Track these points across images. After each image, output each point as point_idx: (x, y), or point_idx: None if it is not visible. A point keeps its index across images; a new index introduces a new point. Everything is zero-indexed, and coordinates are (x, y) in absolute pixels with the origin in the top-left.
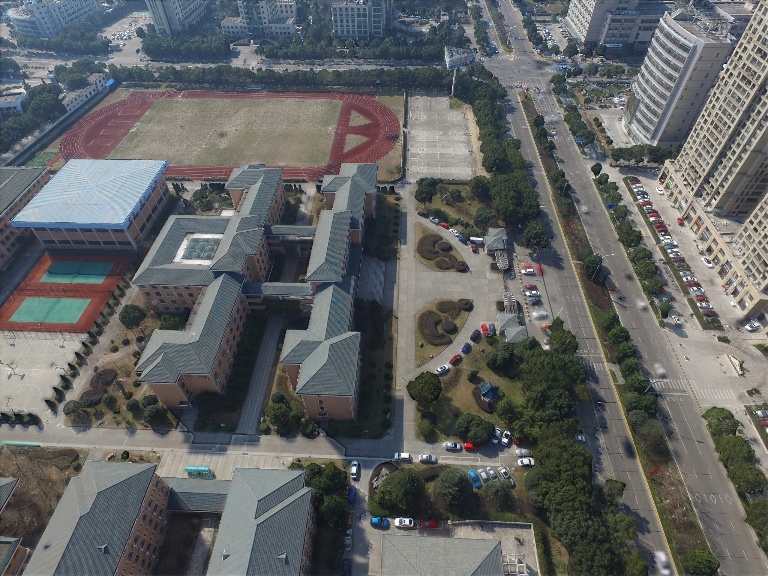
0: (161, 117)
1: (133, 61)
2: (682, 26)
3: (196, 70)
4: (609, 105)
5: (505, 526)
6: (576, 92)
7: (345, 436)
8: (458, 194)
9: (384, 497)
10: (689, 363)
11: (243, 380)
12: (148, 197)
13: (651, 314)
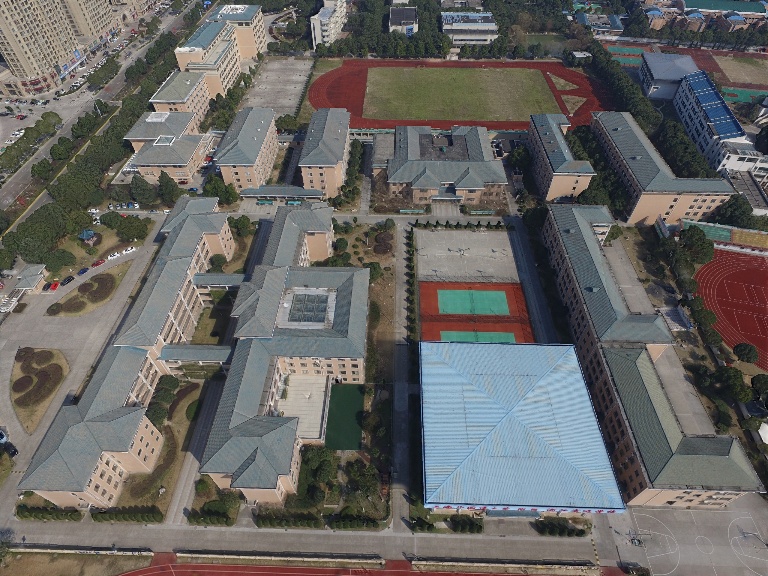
0: None
1: None
2: None
3: None
4: None
5: None
6: None
7: None
8: None
9: None
10: None
11: None
12: None
13: None
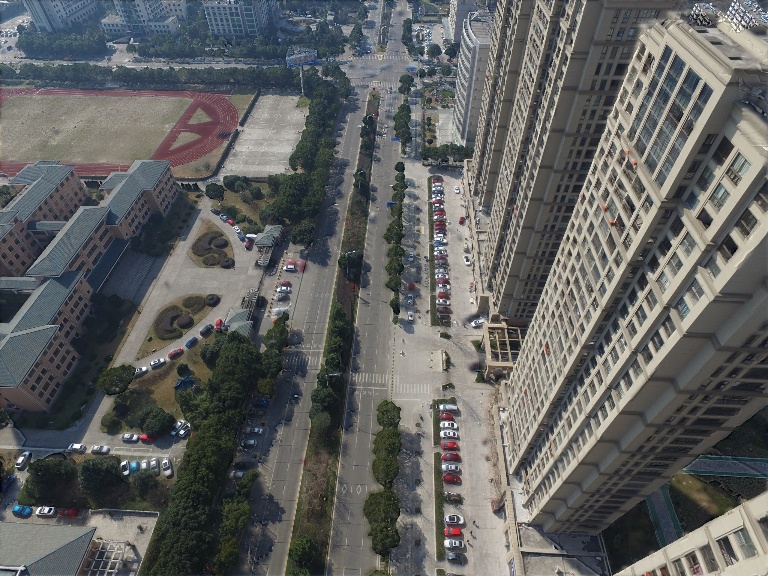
0: (7, 114)
1: (7, 58)
2: (476, 27)
3: (55, 67)
4: (451, 105)
5: (135, 515)
6: (426, 92)
7: (31, 427)
8: (256, 192)
9: (27, 486)
10: (402, 358)
11: None
12: None
13: (390, 310)
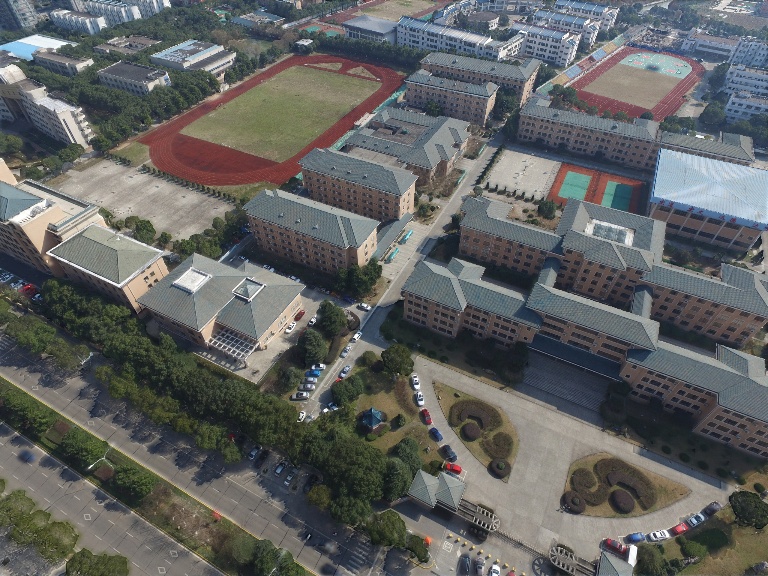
0: None
1: None
2: None
3: None
4: None
5: None
6: None
7: None
8: None
9: None
10: None
11: None
12: (715, 222)
13: None
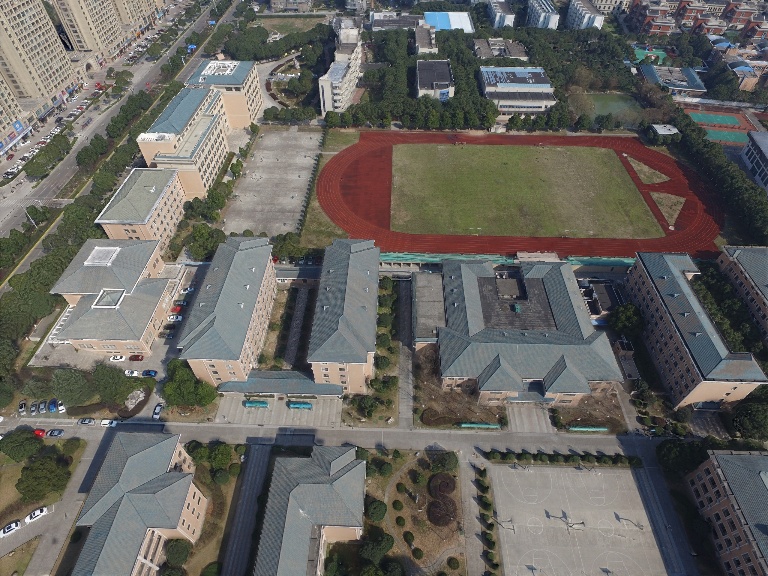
0: None
1: None
2: None
3: None
4: None
5: None
6: None
7: None
8: None
9: (136, 380)
10: None
11: (261, 498)
12: None
13: None
